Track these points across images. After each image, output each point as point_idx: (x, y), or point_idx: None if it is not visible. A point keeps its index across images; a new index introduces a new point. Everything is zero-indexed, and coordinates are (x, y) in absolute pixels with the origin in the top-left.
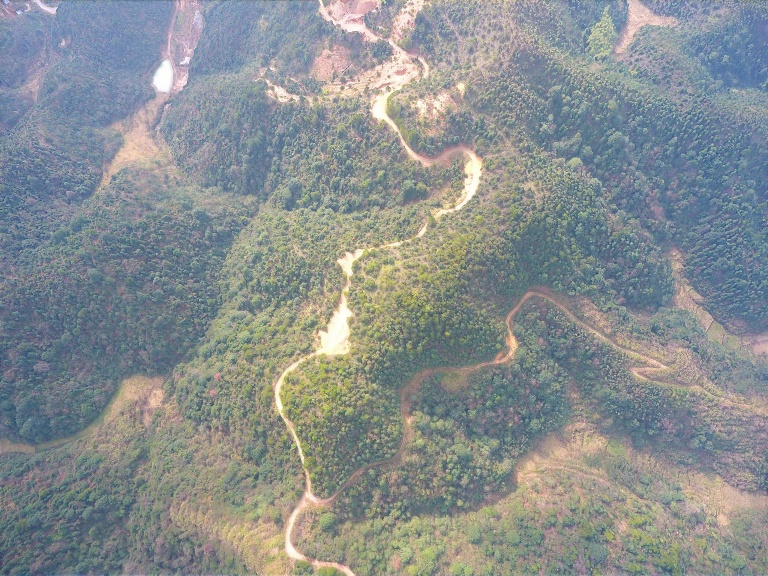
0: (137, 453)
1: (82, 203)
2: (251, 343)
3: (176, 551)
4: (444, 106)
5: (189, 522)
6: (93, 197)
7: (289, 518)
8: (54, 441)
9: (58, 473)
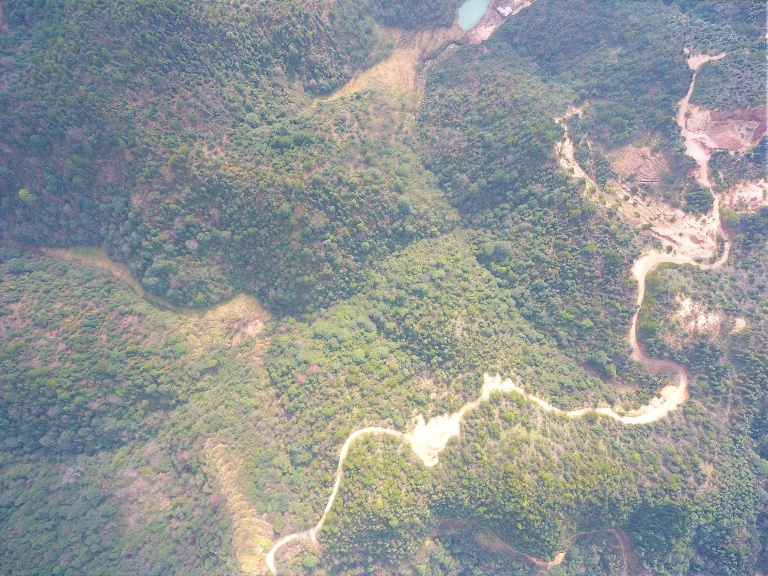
0: (213, 364)
1: (316, 96)
2: (360, 366)
3: (191, 468)
4: (706, 327)
5: (215, 463)
6: (328, 97)
7: (286, 536)
8: (161, 299)
9: (149, 335)
